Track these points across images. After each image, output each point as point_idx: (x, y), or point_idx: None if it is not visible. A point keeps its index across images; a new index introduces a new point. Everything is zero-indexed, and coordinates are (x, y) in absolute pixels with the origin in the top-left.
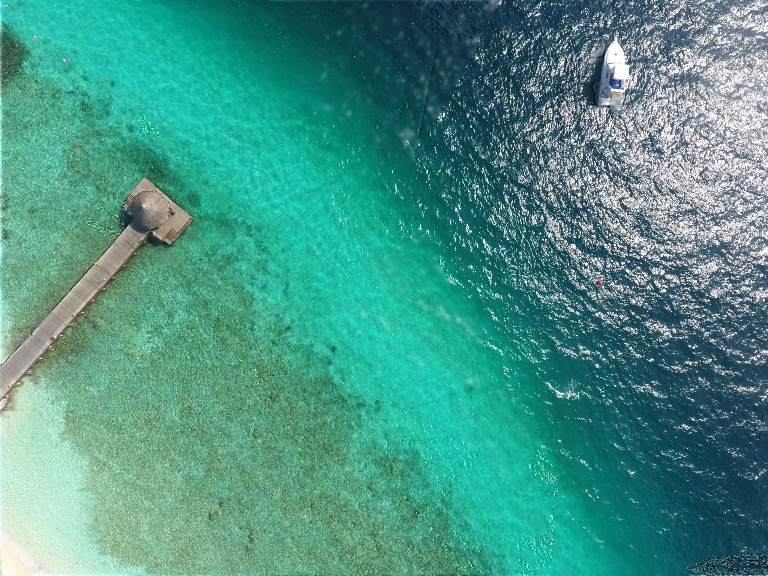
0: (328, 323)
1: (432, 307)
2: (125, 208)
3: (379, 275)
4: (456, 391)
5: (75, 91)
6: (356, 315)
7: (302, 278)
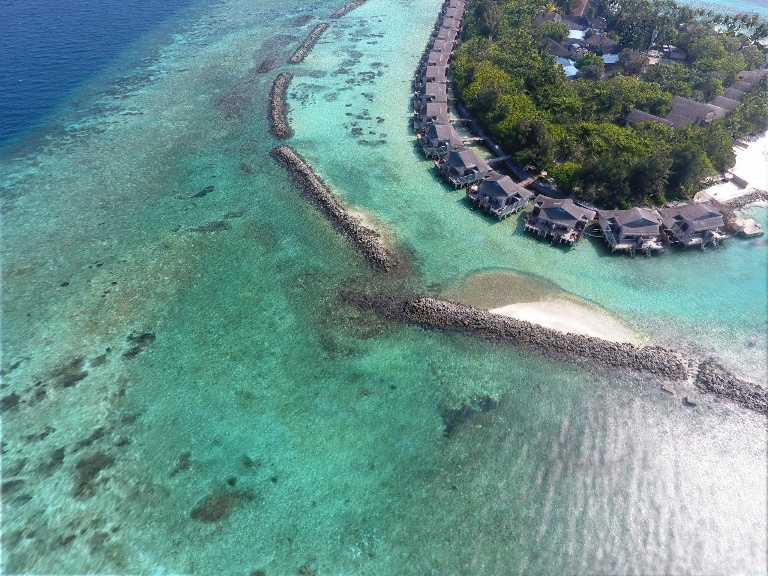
0: None
1: None
2: None
3: None
4: None
5: None
6: None
7: None
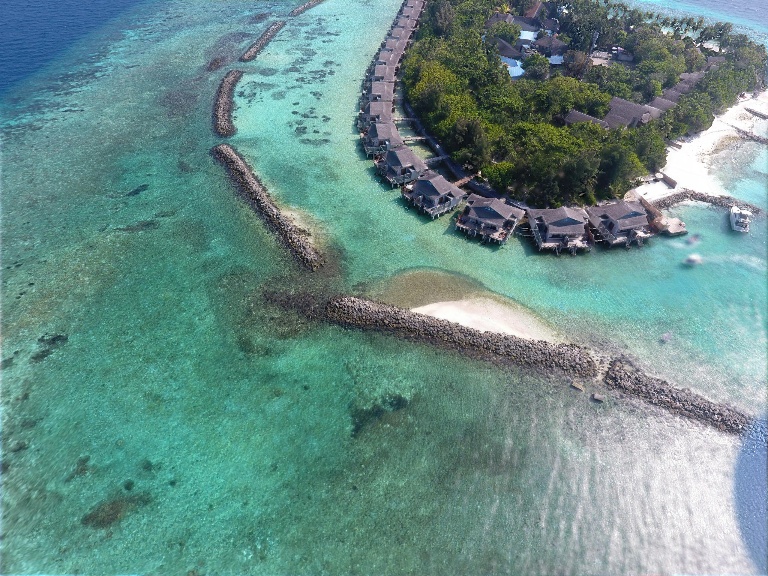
0: None
1: None
2: None
3: None
4: None
5: None
6: None
7: None
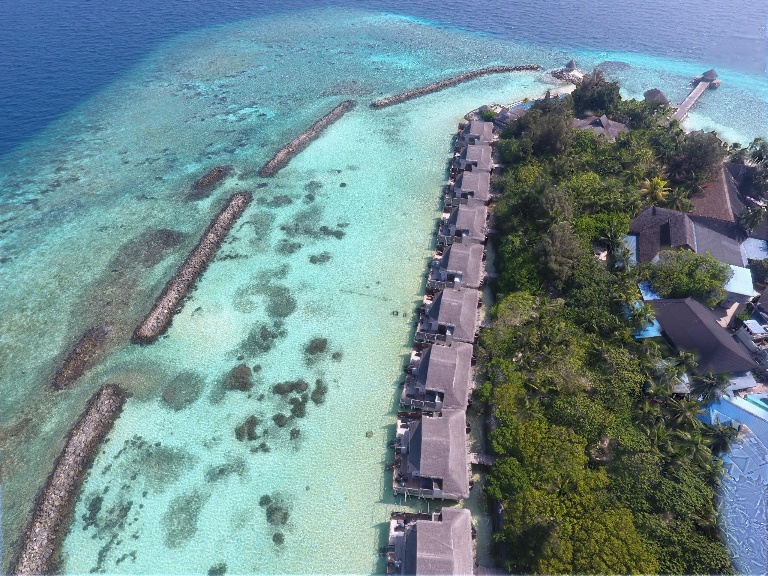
0: None
1: None
2: (696, 79)
3: None
4: None
5: (651, 69)
6: None
7: None
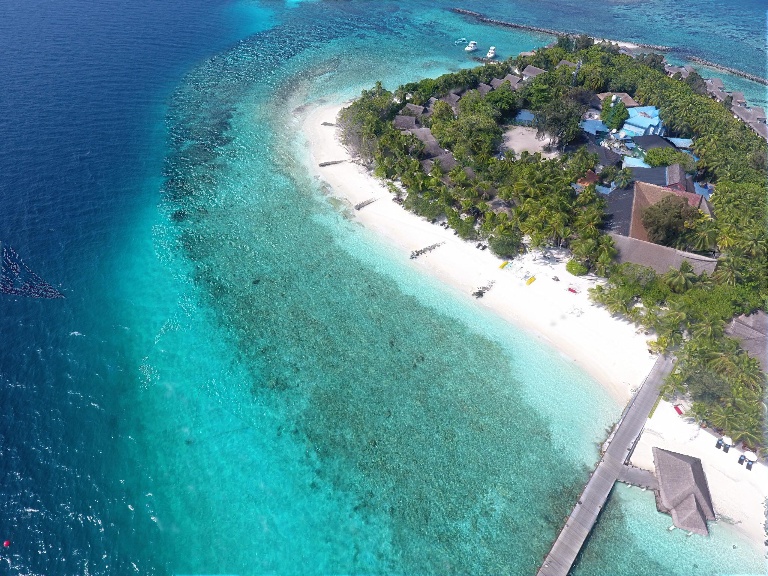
0: (316, 513)
1: (202, 527)
2: None
3: (252, 570)
4: (203, 441)
5: None
6: (285, 521)
7: (339, 567)
